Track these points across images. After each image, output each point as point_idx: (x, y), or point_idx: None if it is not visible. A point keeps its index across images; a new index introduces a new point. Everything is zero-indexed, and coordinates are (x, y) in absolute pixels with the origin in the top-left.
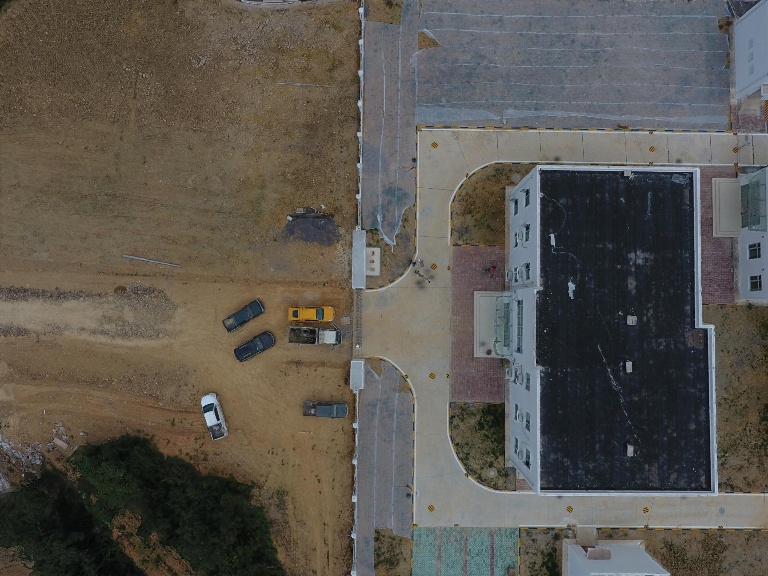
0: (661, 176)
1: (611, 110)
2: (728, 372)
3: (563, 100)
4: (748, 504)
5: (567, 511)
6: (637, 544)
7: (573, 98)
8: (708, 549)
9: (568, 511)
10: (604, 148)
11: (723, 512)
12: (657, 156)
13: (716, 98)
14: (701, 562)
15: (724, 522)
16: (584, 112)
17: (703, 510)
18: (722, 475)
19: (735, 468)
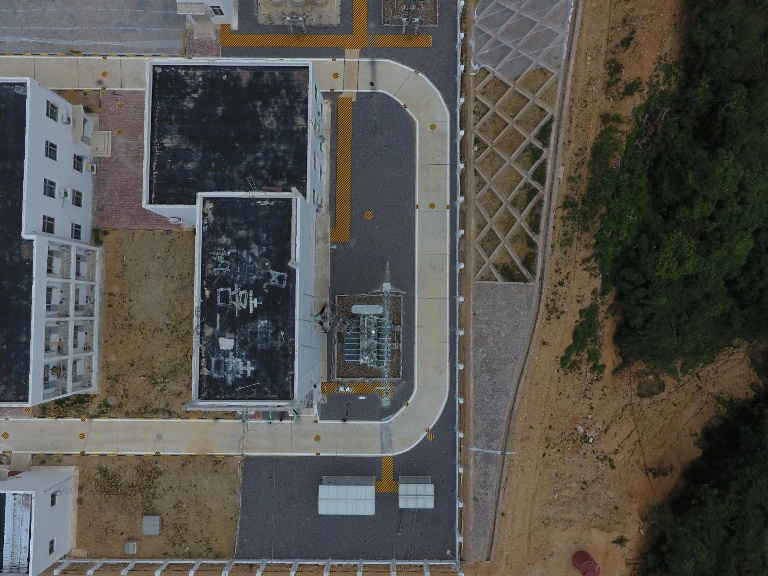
0: (4, 87)
1: (63, 35)
2: (171, 298)
3: (15, 25)
4: (186, 430)
5: (2, 437)
6: (71, 470)
7: (25, 23)
8: (143, 475)
9: (3, 437)
10: (55, 73)
11: (160, 438)
12: (109, 81)
13: (171, 22)
14: (135, 488)
15: (161, 448)
16: (35, 37)
17: (140, 436)
18: (160, 401)
19: (174, 394)
